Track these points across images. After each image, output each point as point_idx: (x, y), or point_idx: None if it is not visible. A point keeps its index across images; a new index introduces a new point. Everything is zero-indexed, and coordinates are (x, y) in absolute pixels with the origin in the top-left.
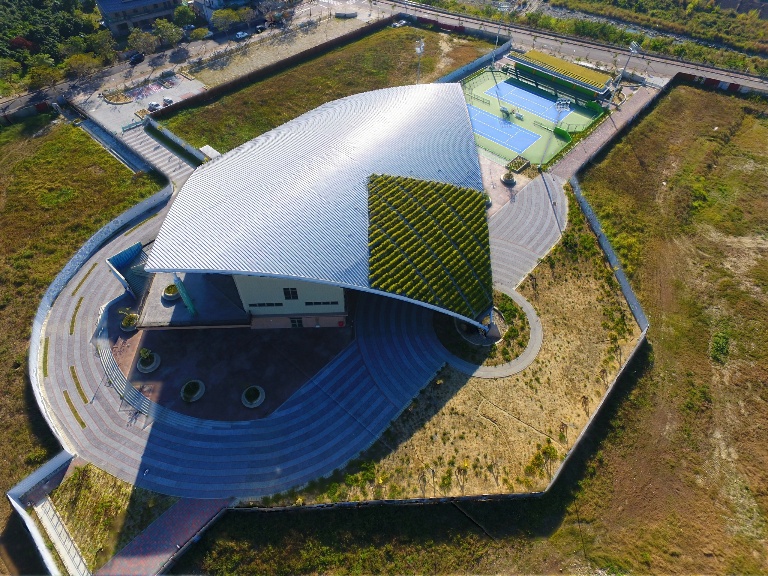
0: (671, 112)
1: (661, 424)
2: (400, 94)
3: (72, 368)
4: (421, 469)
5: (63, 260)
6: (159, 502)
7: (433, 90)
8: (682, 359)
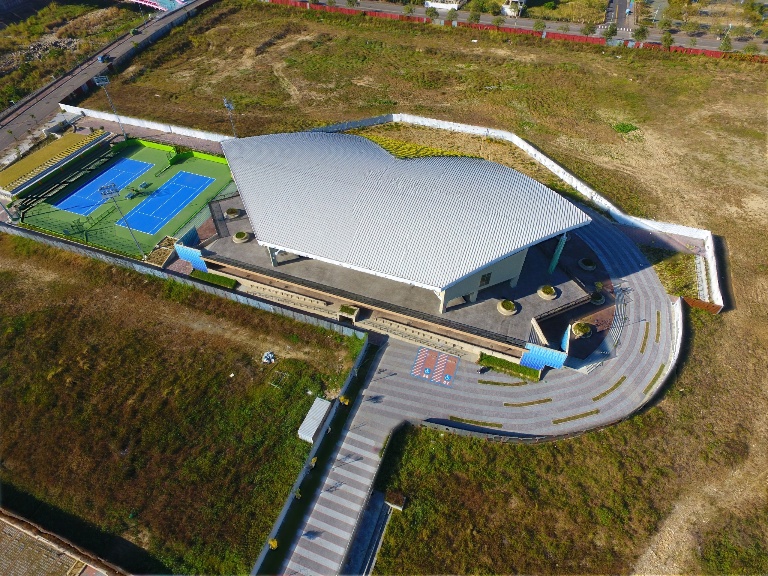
0: (133, 110)
1: (446, 117)
2: (256, 171)
3: (642, 351)
4: (534, 171)
5: (578, 461)
6: (646, 249)
7: (242, 153)
8: (402, 112)
